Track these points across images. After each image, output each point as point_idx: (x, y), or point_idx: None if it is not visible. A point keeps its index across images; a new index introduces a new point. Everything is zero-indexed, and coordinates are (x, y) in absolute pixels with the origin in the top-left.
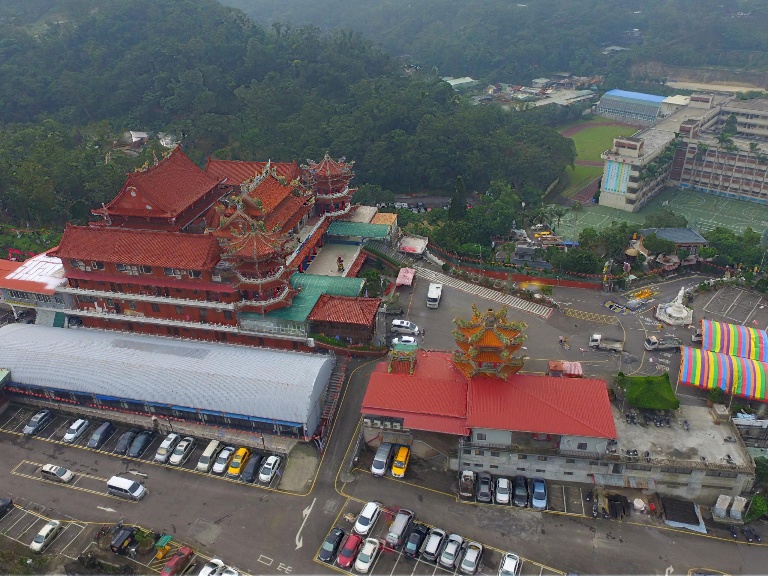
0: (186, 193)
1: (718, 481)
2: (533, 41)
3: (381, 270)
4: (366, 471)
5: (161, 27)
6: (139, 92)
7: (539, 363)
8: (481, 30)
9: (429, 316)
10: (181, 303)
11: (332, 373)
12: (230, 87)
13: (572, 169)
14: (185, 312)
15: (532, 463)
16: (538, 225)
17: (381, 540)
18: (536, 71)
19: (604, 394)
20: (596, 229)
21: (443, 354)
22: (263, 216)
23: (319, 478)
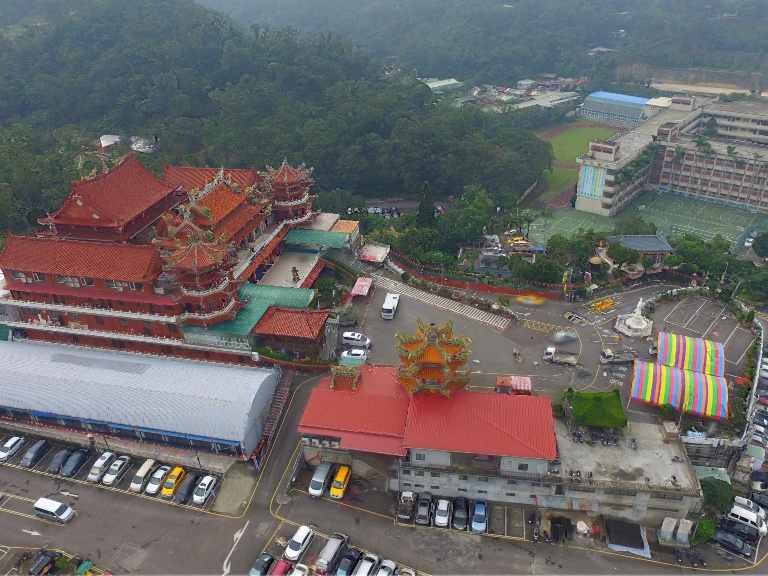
0: (137, 201)
1: (663, 503)
2: (518, 42)
3: (339, 279)
4: (304, 492)
5: (137, 29)
6: (114, 95)
7: (490, 377)
8: (467, 31)
9: (383, 328)
10: (123, 316)
11: (276, 388)
12: (205, 90)
13: (551, 173)
14: (129, 325)
15: (473, 484)
16: (512, 230)
17: (312, 566)
18: (521, 72)
19: (548, 412)
20: (570, 234)
21: (390, 369)
22: (211, 225)
23: (254, 499)
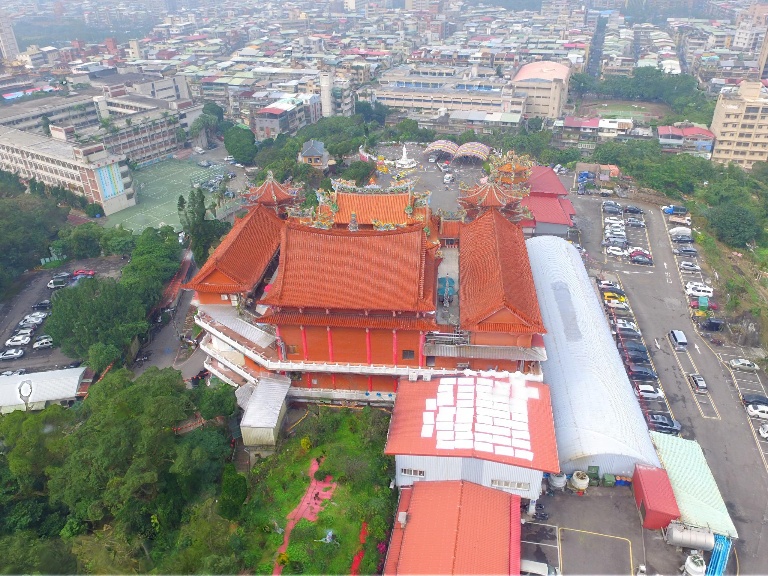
0: None
1: None
2: None
3: None
4: None
5: None
6: None
7: None
8: None
9: None
10: None
11: None
12: None
13: None
14: None
15: None
16: None
17: None
18: None
19: None
20: (166, 220)
21: None
22: None
23: None
